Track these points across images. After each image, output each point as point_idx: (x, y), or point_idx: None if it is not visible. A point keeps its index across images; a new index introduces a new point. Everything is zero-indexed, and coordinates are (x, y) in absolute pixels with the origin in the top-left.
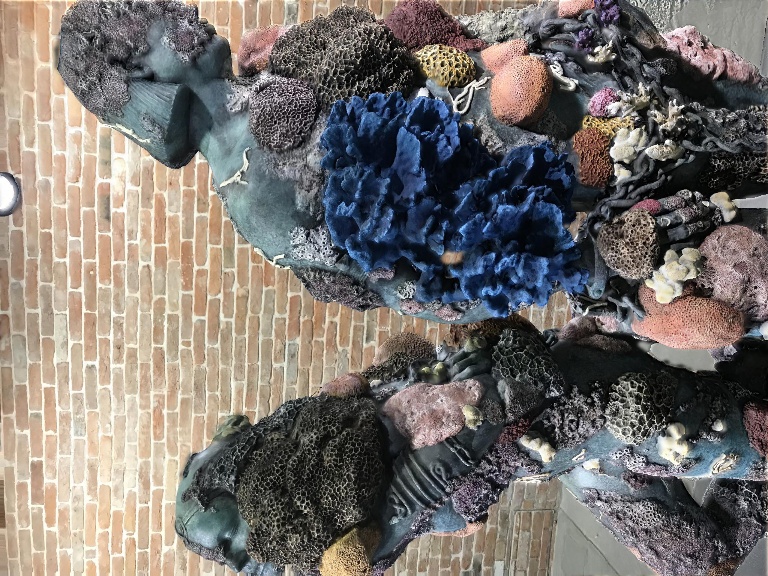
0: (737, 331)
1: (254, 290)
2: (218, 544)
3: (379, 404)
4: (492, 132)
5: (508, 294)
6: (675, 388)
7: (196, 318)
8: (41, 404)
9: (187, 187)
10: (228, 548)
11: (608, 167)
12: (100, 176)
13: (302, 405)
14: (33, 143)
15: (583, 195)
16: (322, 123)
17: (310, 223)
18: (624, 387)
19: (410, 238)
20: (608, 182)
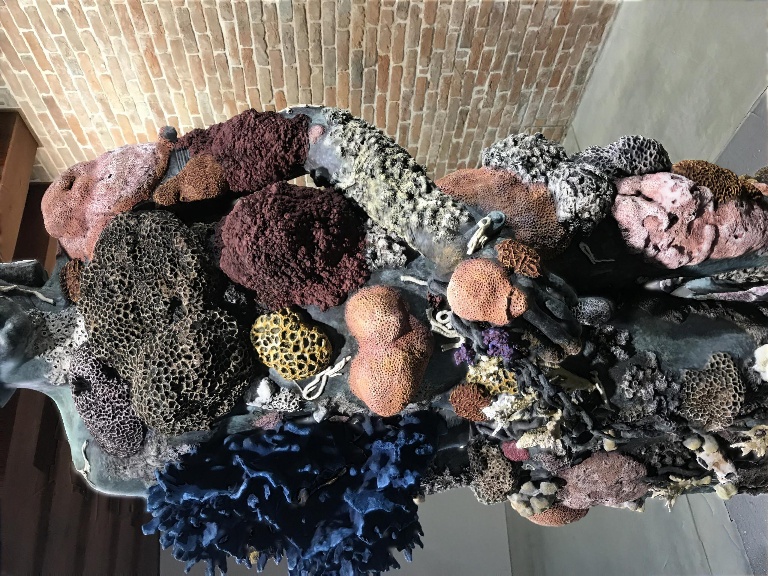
0: None
1: None
2: None
3: None
4: (351, 405)
5: None
6: None
7: None
8: (27, 47)
9: None
10: None
11: (484, 419)
12: None
13: None
14: None
15: None
16: (153, 438)
17: None
18: None
19: None
20: None
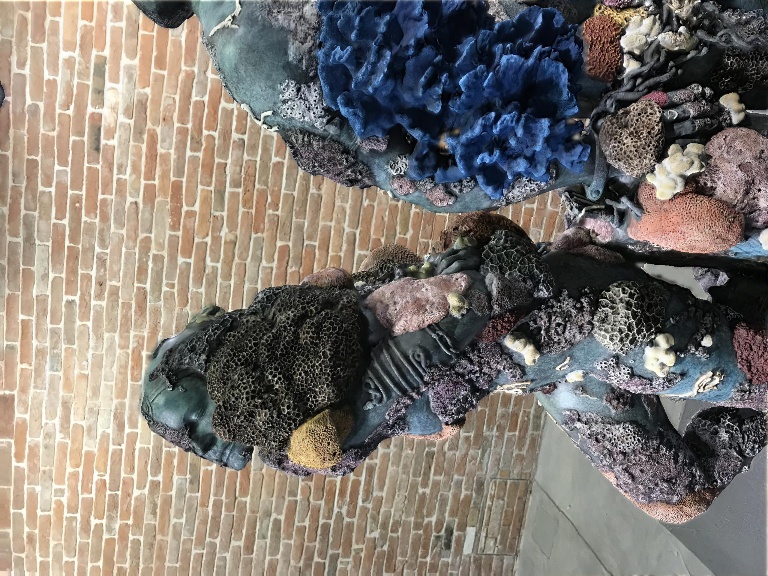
0: (737, 232)
1: (242, 236)
2: (184, 425)
3: (361, 298)
4: (500, 7)
5: (504, 165)
6: (667, 300)
7: (182, 260)
8: (18, 336)
9: (181, 124)
10: (194, 430)
11: (617, 56)
12: (92, 106)
13: (281, 291)
14: (25, 65)
15: (589, 89)
16: None
17: (302, 78)
18: (615, 293)
19: (406, 96)
20: (616, 73)
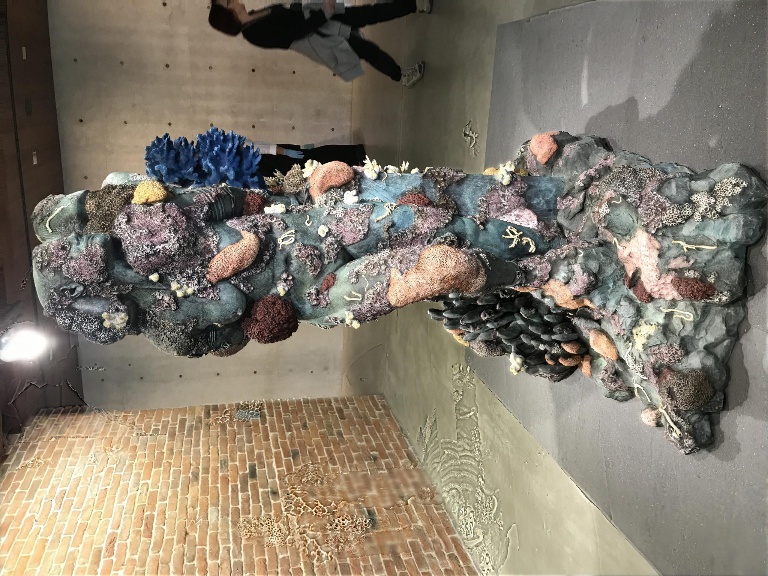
0: None
1: None
2: None
3: None
4: None
5: None
6: None
7: None
8: None
9: None
10: None
11: None
12: None
13: None
14: None
15: None
16: None
17: None
18: None
19: (182, 157)
20: None
